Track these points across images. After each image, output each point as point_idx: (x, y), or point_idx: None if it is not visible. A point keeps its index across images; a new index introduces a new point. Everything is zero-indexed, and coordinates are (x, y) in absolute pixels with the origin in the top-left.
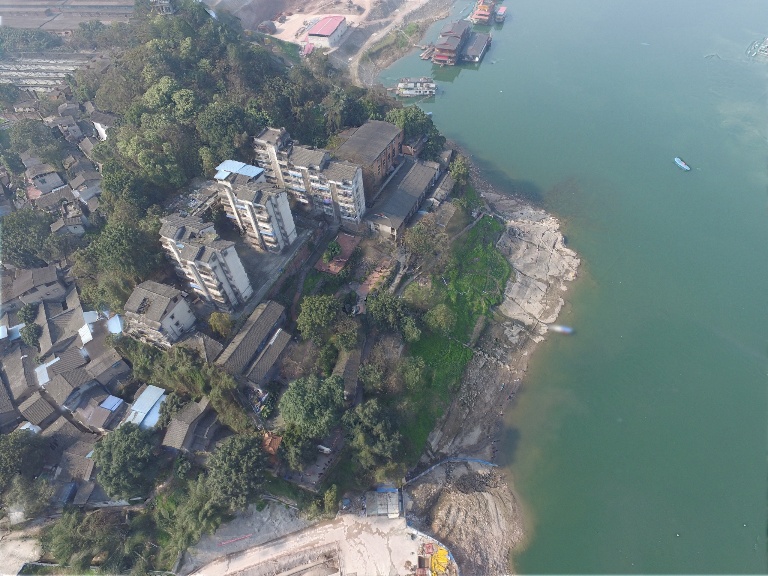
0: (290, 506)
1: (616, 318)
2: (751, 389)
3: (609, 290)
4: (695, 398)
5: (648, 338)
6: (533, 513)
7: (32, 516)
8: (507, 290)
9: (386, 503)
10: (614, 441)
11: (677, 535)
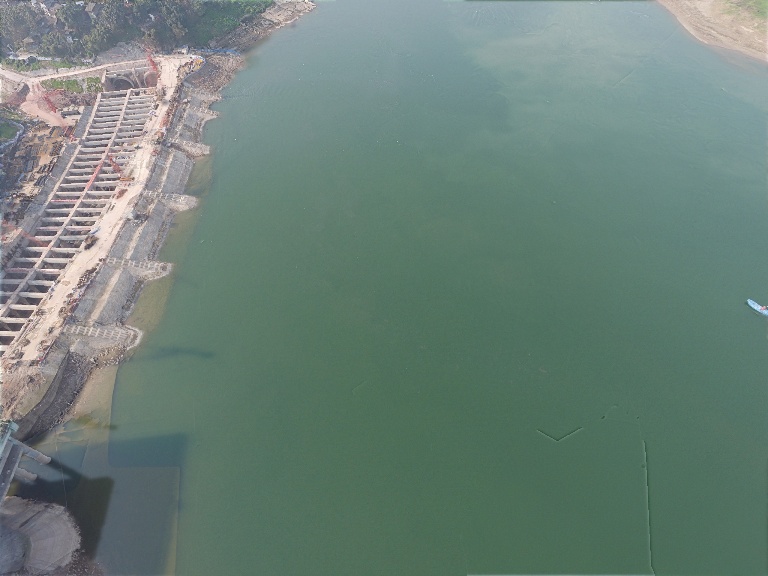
0: (141, 47)
1: None
2: (365, 35)
3: None
4: (338, 38)
5: None
6: (249, 64)
7: (33, 38)
8: (268, 9)
9: (182, 49)
10: (295, 49)
11: (303, 65)
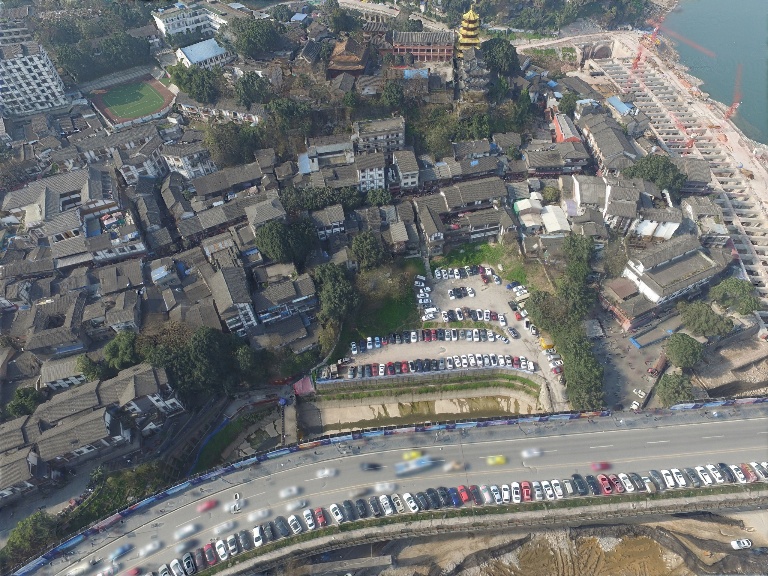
0: (593, 23)
1: (702, 8)
2: (764, 20)
3: (698, 2)
4: None
5: (718, 11)
6: None
7: (510, 12)
8: None
9: None
10: (707, 30)
11: (734, 43)
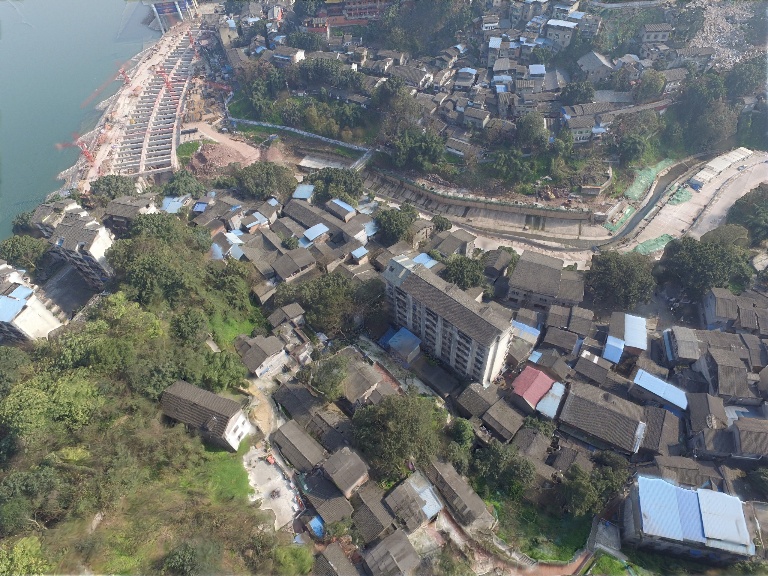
0: None
1: None
2: None
3: None
4: None
5: None
6: None
7: None
8: None
9: None
10: None
11: None
